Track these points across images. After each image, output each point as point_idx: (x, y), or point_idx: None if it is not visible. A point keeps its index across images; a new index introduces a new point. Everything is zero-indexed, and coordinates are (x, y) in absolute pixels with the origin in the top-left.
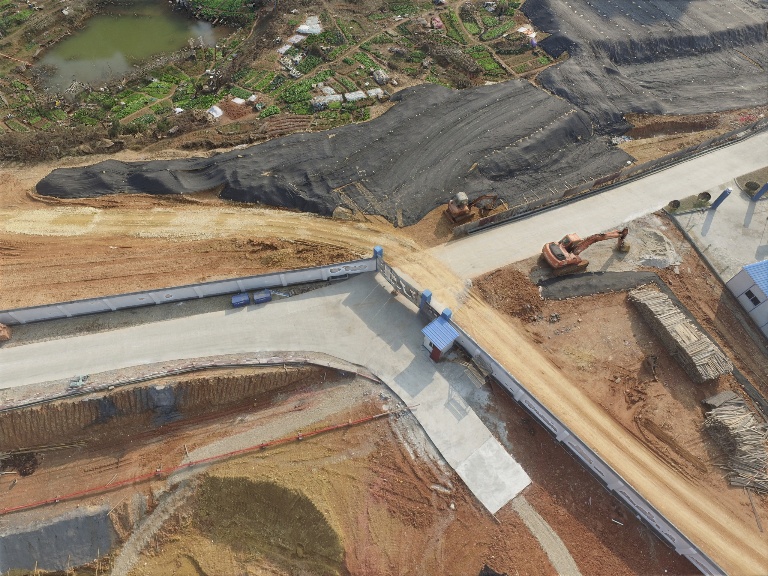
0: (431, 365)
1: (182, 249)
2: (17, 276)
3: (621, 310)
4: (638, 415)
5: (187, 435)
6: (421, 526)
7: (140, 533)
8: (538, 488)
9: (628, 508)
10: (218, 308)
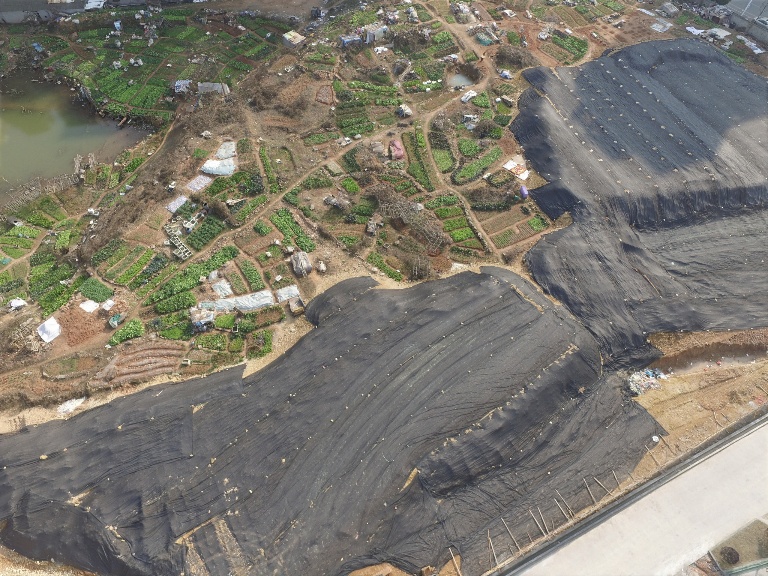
0: None
1: None
2: None
3: None
4: None
5: None
6: None
7: None
8: None
9: None
10: None
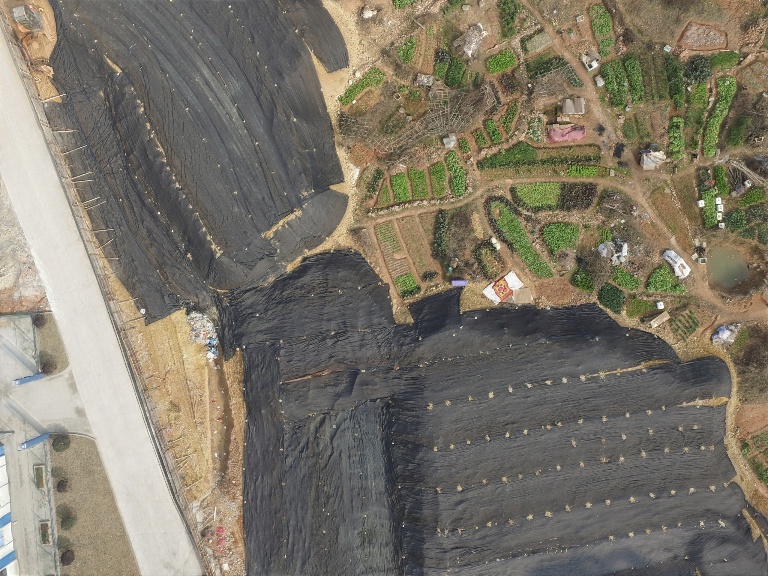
0: None
1: None
2: None
3: None
4: None
5: None
6: None
7: None
8: None
9: None
10: None
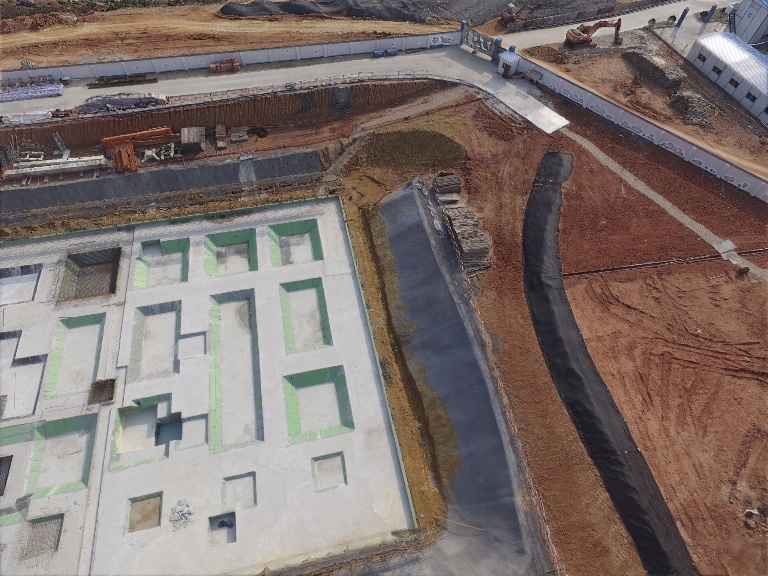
0: (503, 80)
1: (331, 36)
2: (229, 47)
3: (618, 60)
4: (631, 99)
5: (357, 119)
6: (508, 140)
7: (336, 165)
8: (574, 125)
9: (627, 131)
10: (365, 58)
